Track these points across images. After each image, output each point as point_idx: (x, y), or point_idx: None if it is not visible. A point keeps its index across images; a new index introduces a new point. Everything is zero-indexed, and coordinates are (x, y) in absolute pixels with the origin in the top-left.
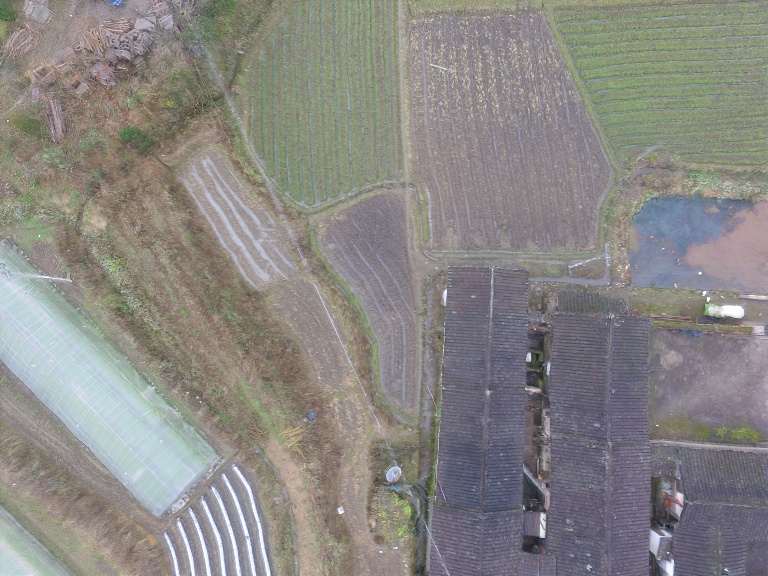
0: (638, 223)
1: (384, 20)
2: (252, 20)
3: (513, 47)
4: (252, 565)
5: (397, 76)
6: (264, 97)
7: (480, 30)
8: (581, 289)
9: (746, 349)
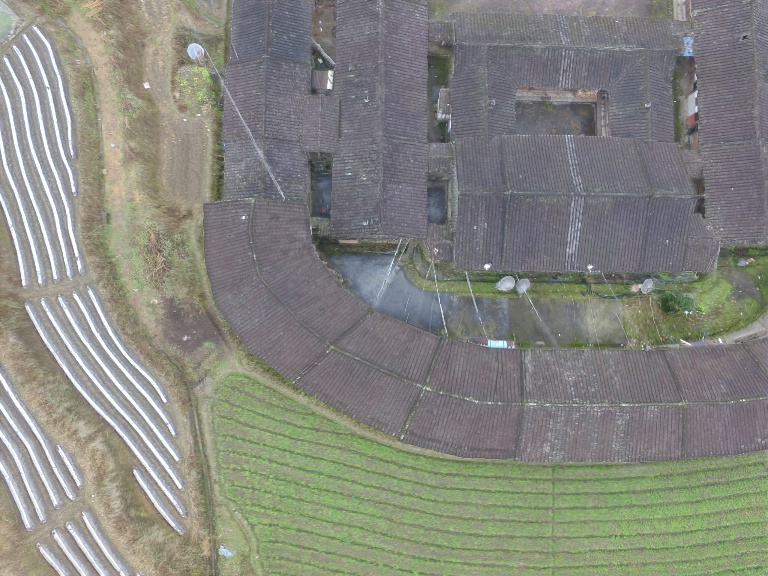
0: None
1: None
2: None
3: None
4: (53, 112)
5: None
6: None
7: None
8: None
9: None
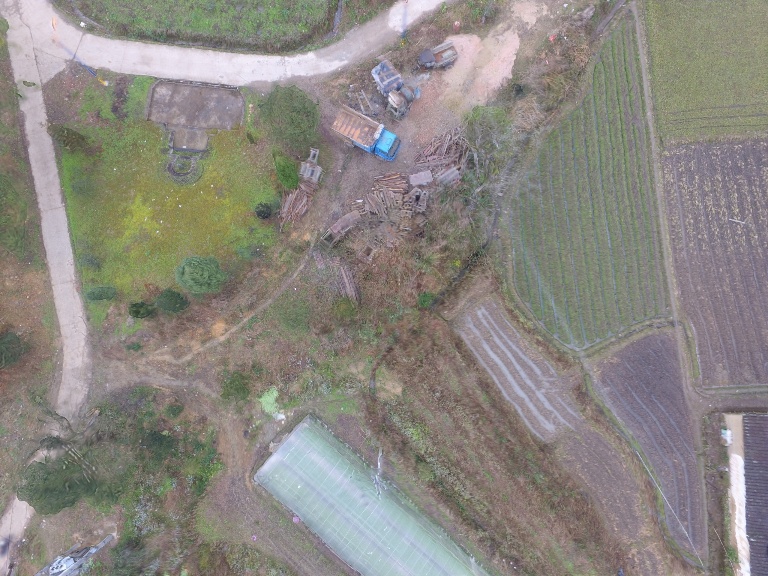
0: None
1: (638, 154)
2: (509, 161)
3: (767, 176)
4: None
5: (656, 211)
6: (525, 238)
7: (732, 159)
8: None
9: None
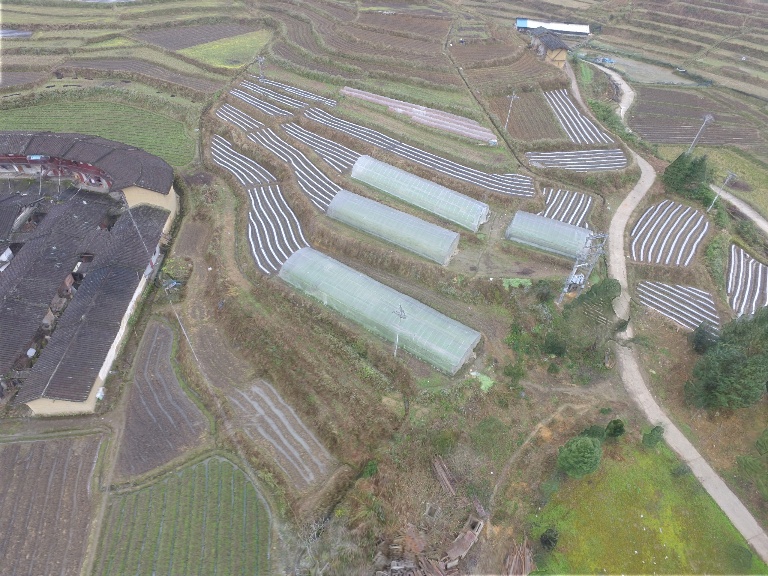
0: None
1: None
2: None
3: None
4: (260, 239)
5: None
6: (254, 573)
7: None
8: None
9: None
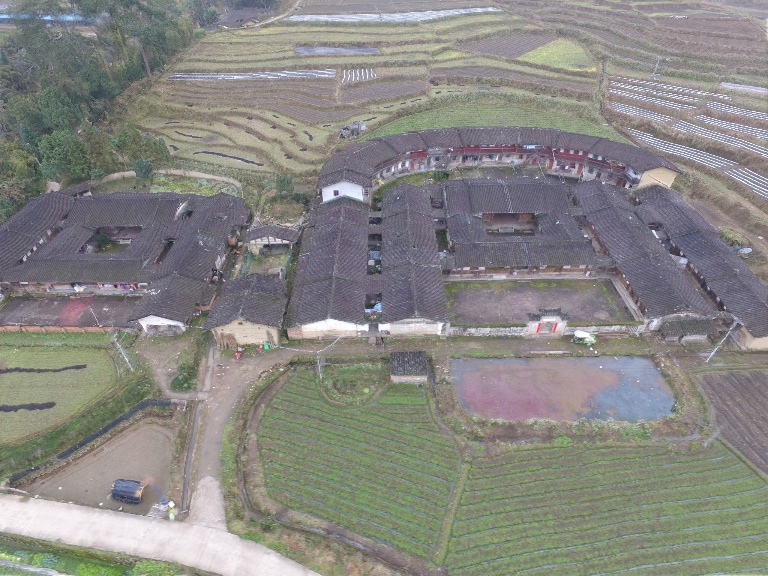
0: (669, 398)
1: None
2: None
3: None
4: None
5: None
6: None
7: None
8: (689, 349)
9: None
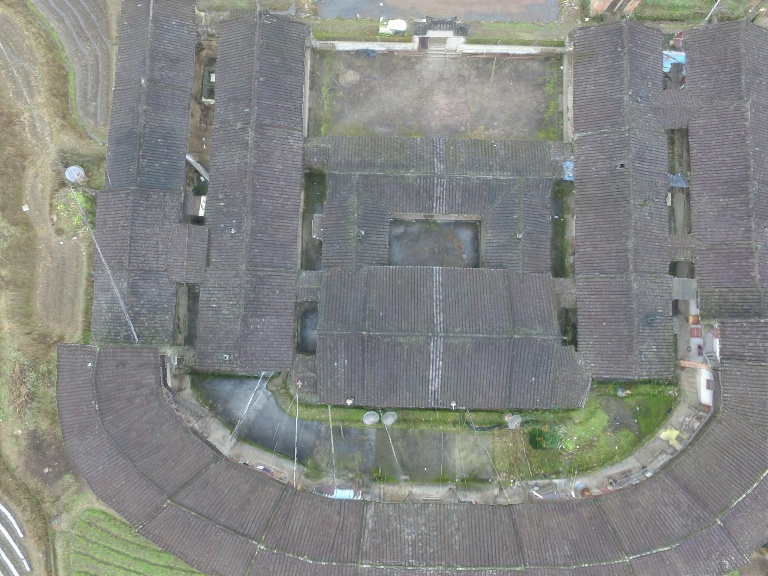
0: None
1: None
2: None
3: None
4: None
5: None
6: None
7: None
8: None
9: (418, 66)
